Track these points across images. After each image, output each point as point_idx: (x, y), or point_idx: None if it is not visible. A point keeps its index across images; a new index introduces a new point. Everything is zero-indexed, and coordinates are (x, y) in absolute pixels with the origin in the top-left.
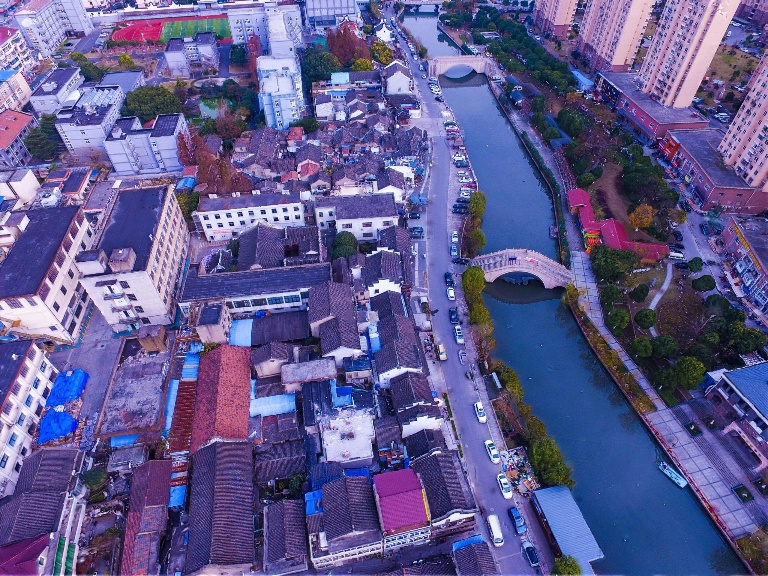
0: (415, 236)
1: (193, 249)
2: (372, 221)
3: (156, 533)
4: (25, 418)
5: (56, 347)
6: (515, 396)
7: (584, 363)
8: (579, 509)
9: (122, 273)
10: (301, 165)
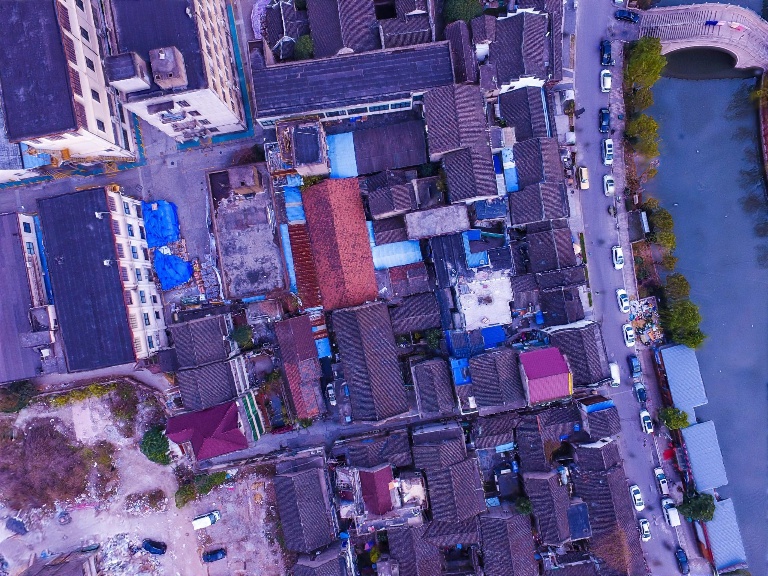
0: None
1: None
2: None
3: (315, 380)
4: (140, 271)
5: (118, 165)
6: (666, 250)
7: (742, 178)
8: (698, 365)
9: (178, 94)
10: None
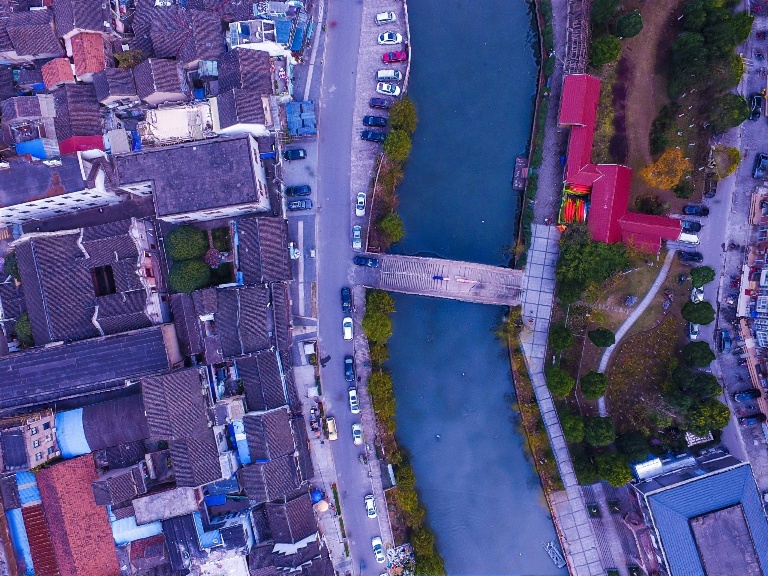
0: (297, 209)
1: None
2: (219, 210)
3: None
4: None
5: None
6: None
7: (509, 399)
8: None
9: None
10: (69, 36)
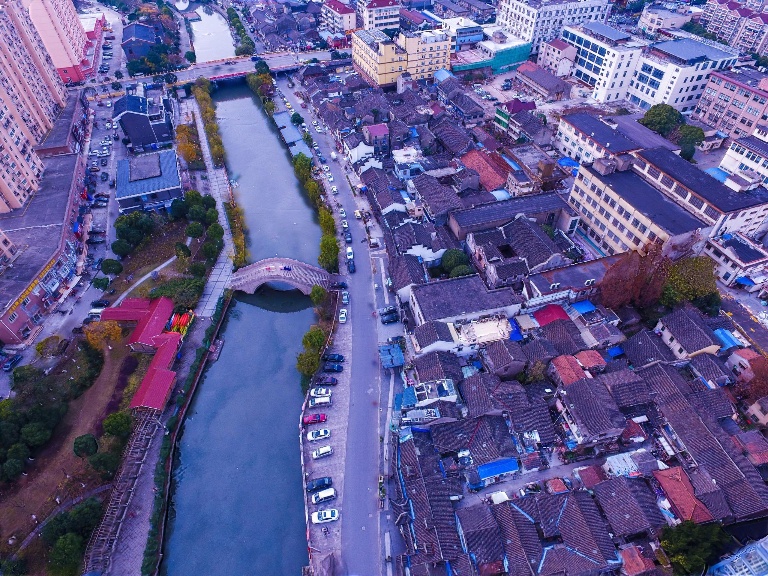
0: None
1: None
2: None
3: None
4: None
5: None
6: None
7: None
8: None
9: None
10: None
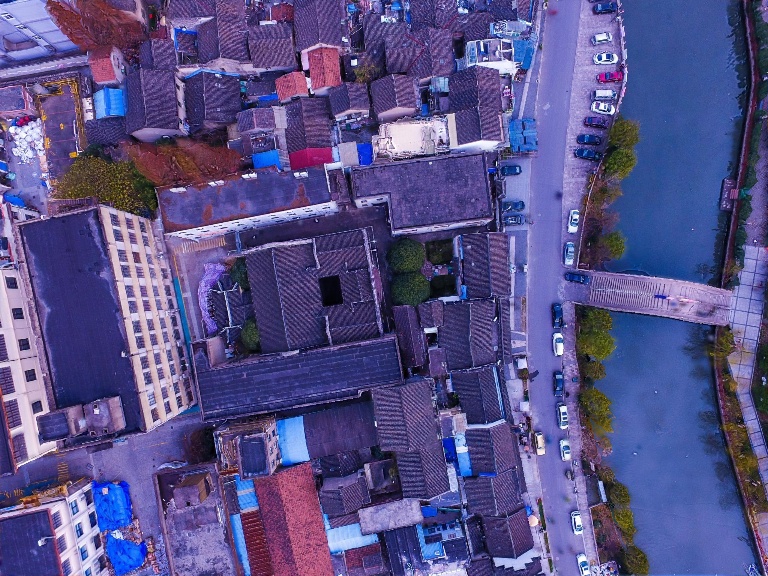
0: (512, 224)
1: (175, 257)
2: None
3: None
4: (91, 569)
5: None
6: (623, 527)
7: (701, 418)
8: None
9: (115, 439)
10: (307, 50)
